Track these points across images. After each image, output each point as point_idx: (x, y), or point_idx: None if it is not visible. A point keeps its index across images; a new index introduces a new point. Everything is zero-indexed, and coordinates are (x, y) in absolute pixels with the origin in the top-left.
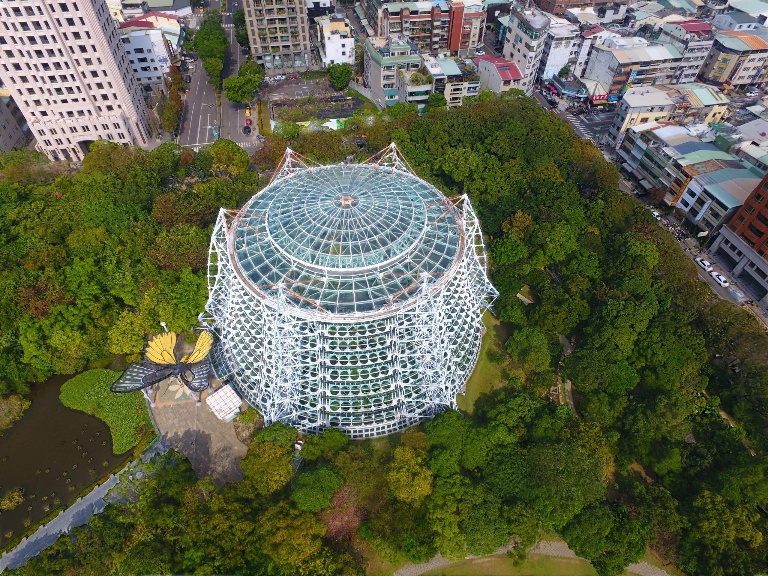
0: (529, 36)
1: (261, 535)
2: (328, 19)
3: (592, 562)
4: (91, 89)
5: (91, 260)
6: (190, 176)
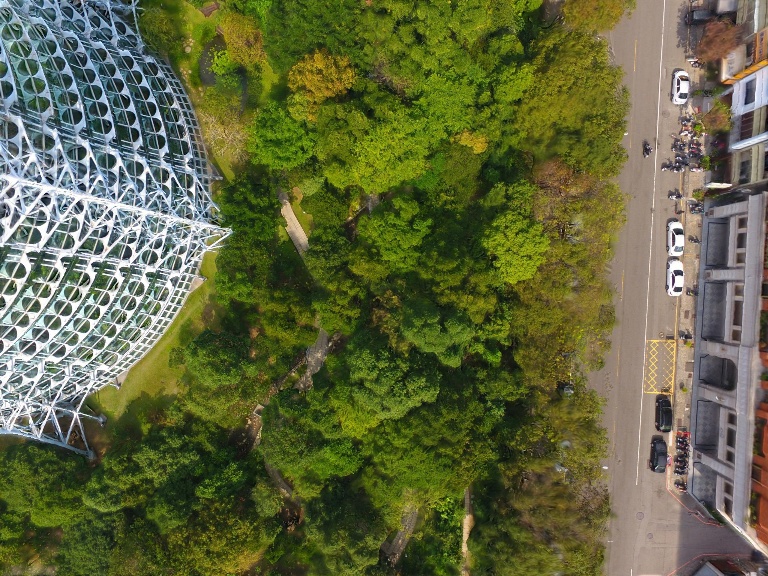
0: None
1: None
2: None
3: None
4: None
5: None
6: None
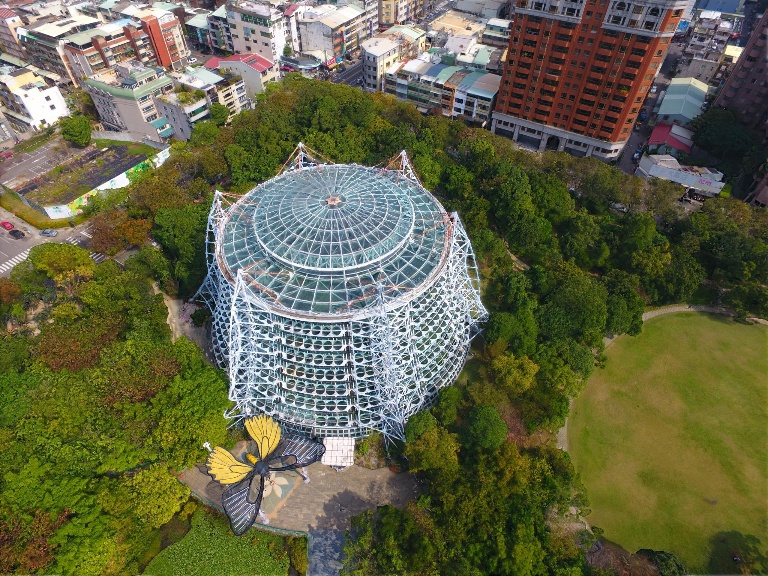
0: (262, 25)
1: None
2: (6, 75)
3: (626, 332)
4: None
5: (34, 460)
6: (31, 308)
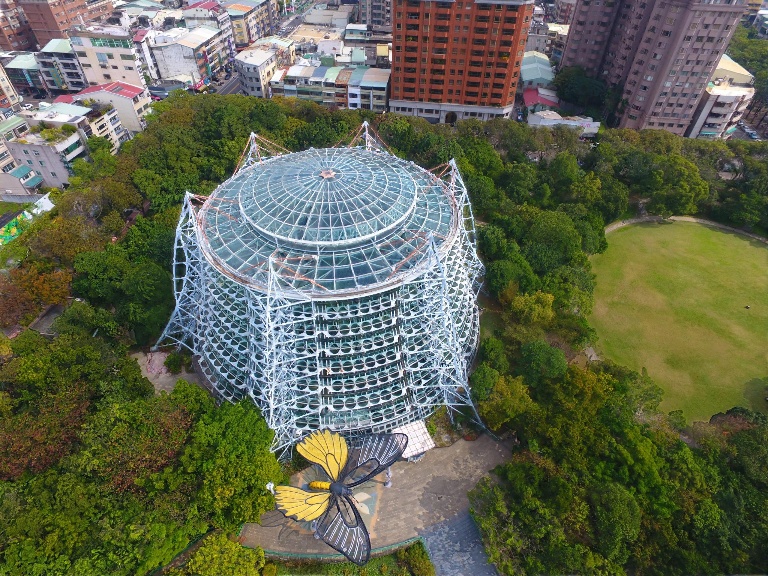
0: (121, 47)
1: None
2: None
3: None
4: None
5: None
6: None
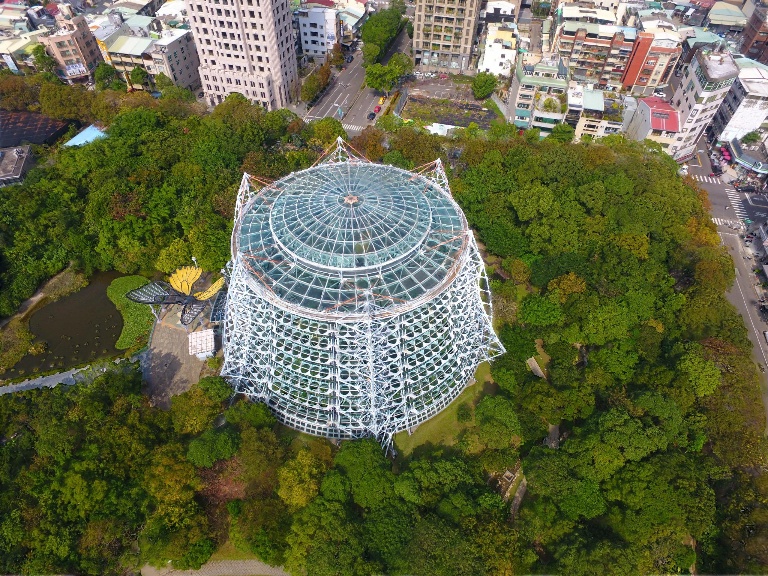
0: (701, 85)
1: (152, 462)
2: (497, 27)
3: None
4: (251, 50)
5: (174, 188)
6: (291, 143)
